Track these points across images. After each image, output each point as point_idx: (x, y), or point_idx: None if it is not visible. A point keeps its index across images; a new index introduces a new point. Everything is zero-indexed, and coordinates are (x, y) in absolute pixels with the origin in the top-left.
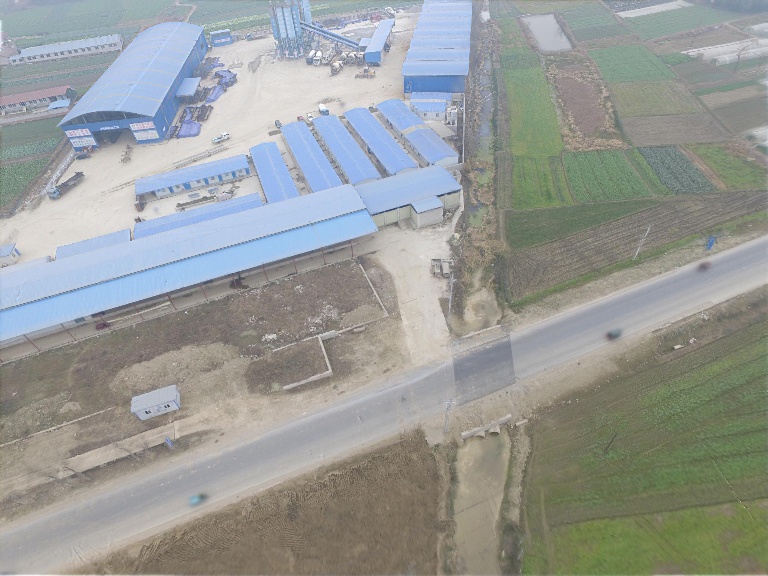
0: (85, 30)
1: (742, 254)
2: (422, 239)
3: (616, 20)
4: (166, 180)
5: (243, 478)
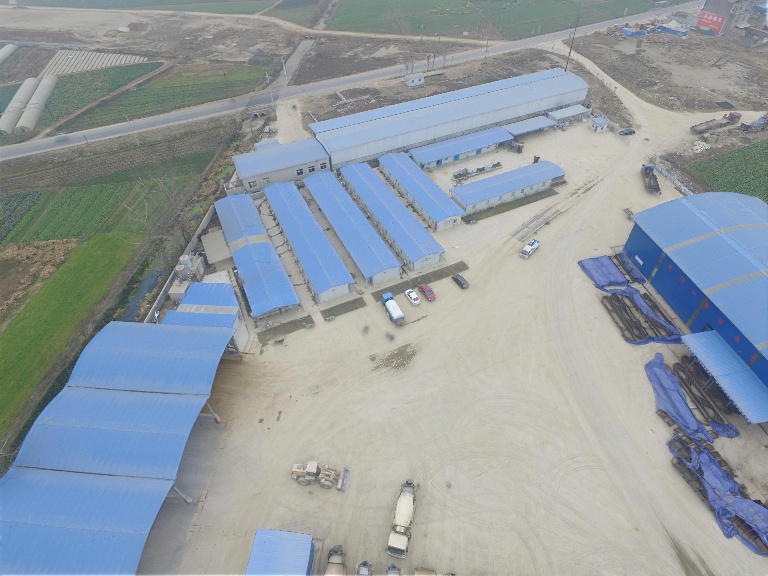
0: None
1: (70, 143)
2: None
3: None
4: (529, 170)
5: (368, 74)
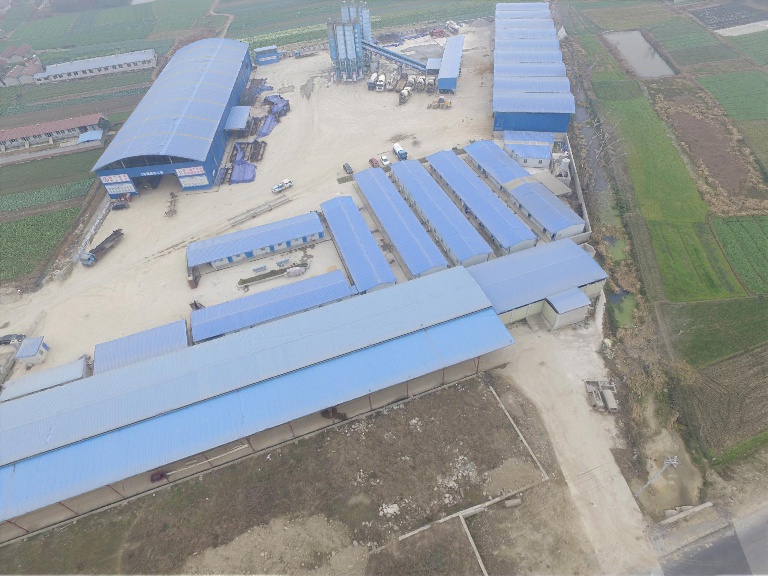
0: (114, 43)
1: None
2: (563, 347)
3: (717, 39)
4: (224, 247)
5: None
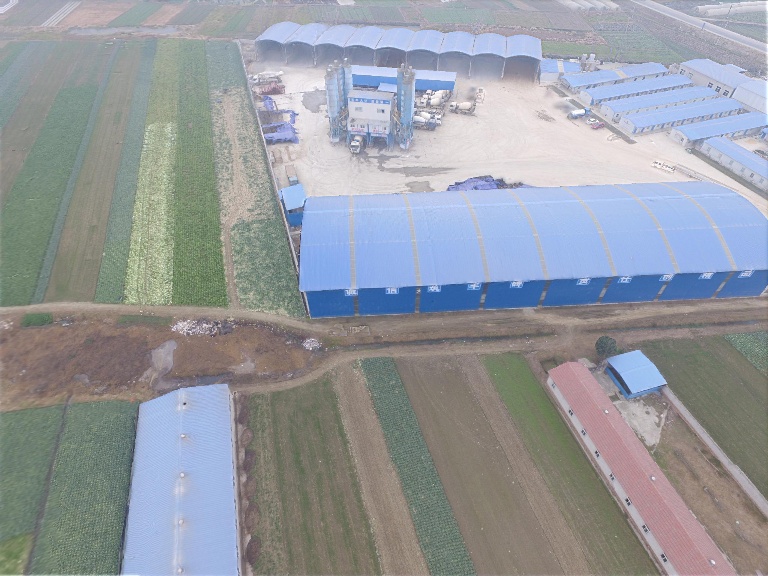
0: None
1: None
2: None
3: (360, 7)
4: None
5: None
